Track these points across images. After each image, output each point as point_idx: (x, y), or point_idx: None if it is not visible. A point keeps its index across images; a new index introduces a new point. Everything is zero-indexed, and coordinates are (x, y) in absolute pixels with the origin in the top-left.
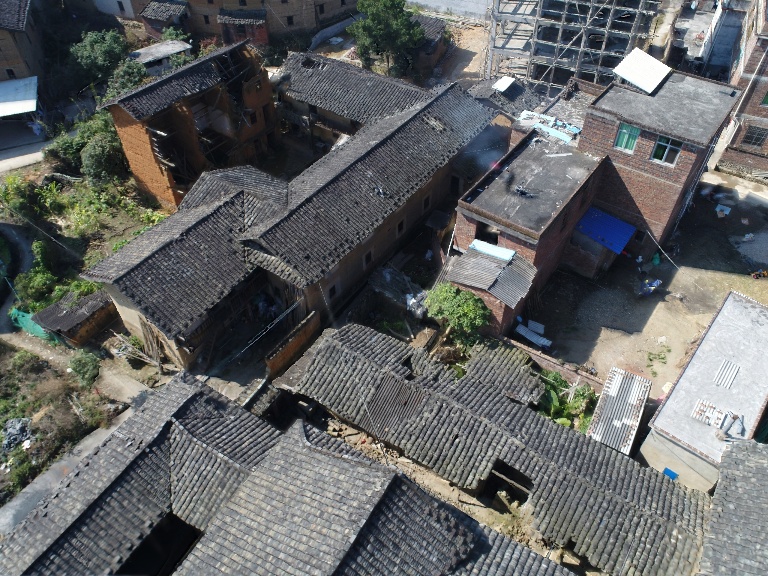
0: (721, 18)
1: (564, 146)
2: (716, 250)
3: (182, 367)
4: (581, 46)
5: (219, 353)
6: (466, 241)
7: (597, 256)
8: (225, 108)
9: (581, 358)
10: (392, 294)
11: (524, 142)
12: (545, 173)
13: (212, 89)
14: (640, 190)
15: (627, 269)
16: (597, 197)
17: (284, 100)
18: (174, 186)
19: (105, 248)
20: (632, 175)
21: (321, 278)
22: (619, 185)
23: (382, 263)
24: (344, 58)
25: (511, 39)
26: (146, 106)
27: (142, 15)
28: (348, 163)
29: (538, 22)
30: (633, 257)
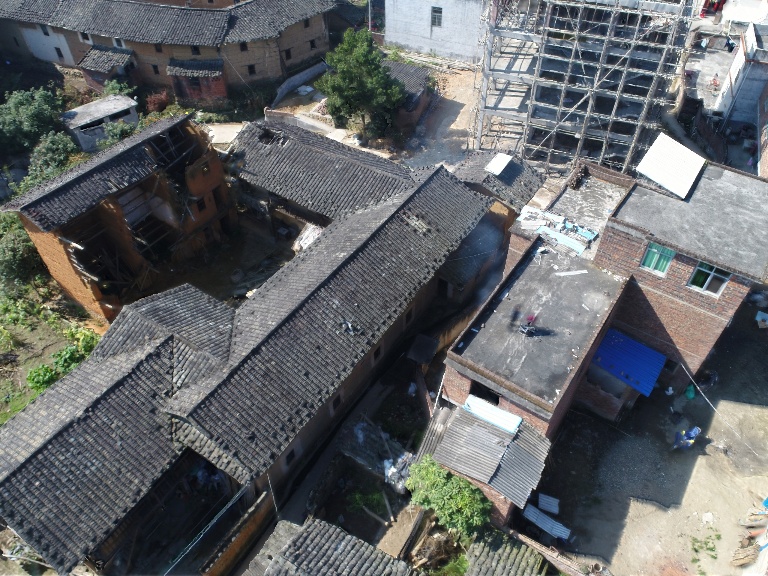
0: (744, 70)
1: (576, 259)
2: (760, 374)
3: (94, 572)
4: (587, 111)
5: (145, 546)
6: (458, 394)
7: (621, 400)
8: (165, 196)
9: (607, 548)
10: (366, 462)
11: (527, 254)
12: (555, 302)
13: (147, 178)
14: (673, 317)
15: (655, 405)
16: (617, 318)
17: (239, 178)
18: (102, 298)
19: (18, 375)
20: (663, 300)
21: (270, 466)
22: (646, 309)
23: (355, 399)
24: (314, 113)
25: (504, 96)
26: (58, 212)
27: (80, 66)
28: (308, 289)
29: (536, 82)
30: (661, 387)
